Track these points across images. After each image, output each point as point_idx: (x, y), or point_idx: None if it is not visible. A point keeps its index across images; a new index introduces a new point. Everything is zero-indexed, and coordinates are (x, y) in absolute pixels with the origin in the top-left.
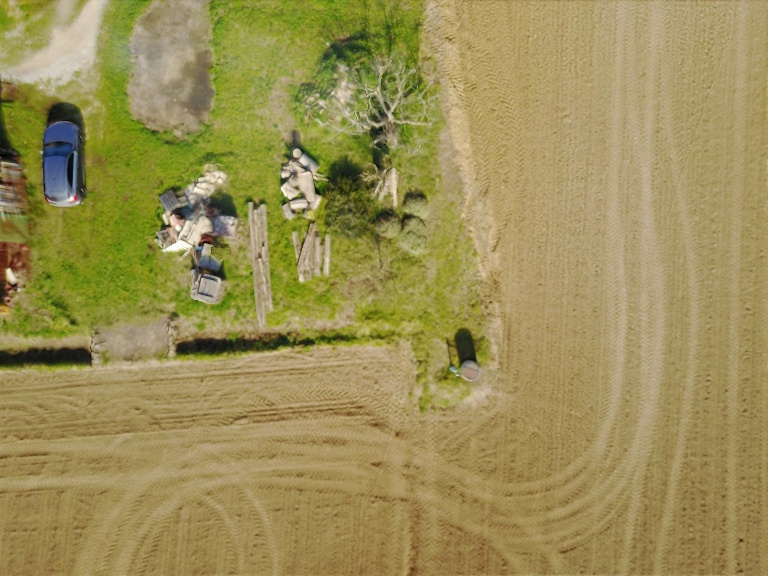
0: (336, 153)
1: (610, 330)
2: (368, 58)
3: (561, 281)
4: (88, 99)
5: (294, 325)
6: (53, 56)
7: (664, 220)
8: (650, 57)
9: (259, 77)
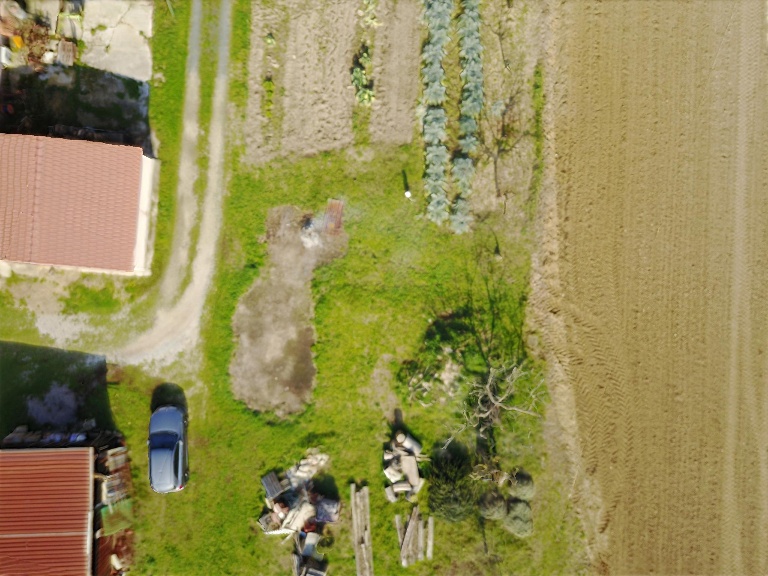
0: (438, 431)
1: None
2: (472, 339)
3: (674, 568)
4: (191, 379)
5: None
6: (157, 336)
7: None
8: (766, 334)
9: (361, 355)
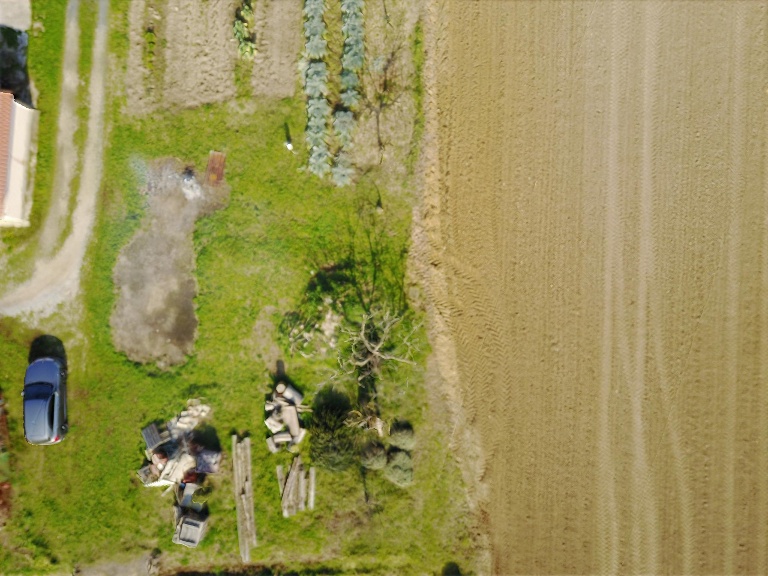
0: (320, 382)
1: (600, 565)
2: (352, 290)
3: (550, 514)
4: (70, 331)
5: (278, 558)
6: (35, 289)
7: (654, 452)
8: (638, 285)
9: (242, 307)
